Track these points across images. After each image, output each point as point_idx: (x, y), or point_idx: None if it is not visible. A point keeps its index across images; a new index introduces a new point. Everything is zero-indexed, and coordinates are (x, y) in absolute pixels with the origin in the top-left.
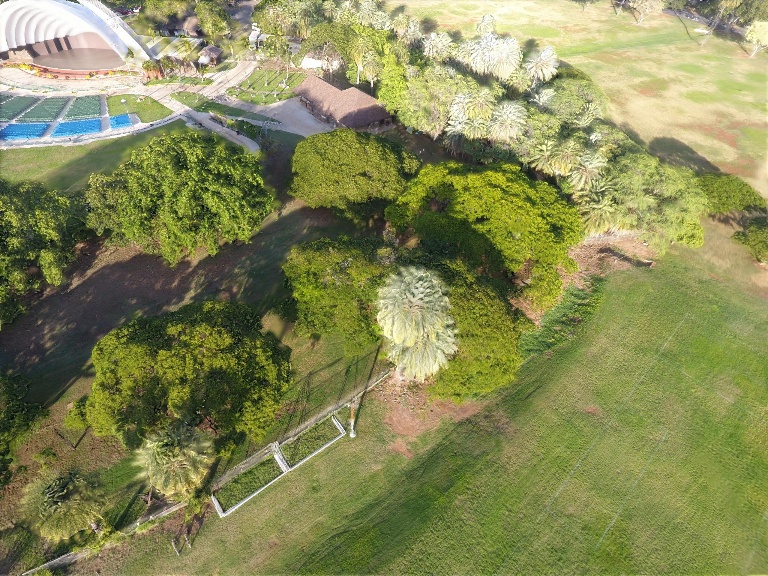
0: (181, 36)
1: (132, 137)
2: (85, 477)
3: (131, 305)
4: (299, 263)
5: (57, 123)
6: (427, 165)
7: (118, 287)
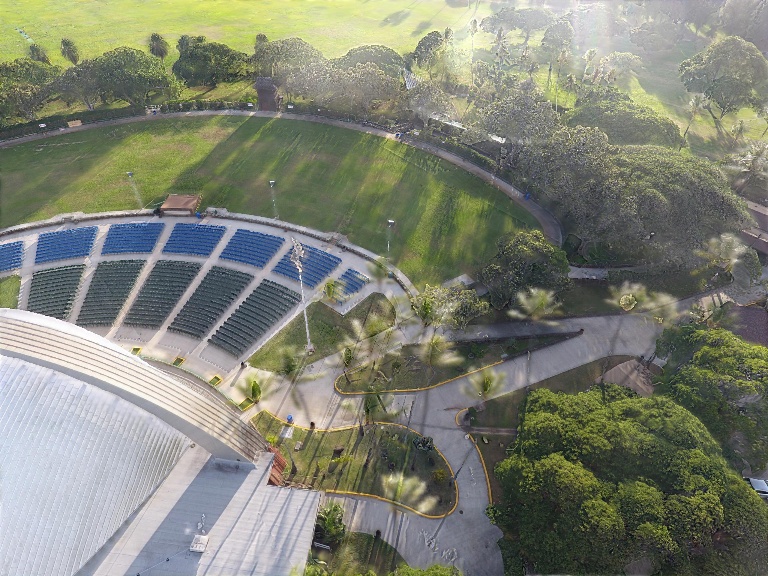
0: None
1: (3, 223)
2: (62, 49)
3: None
4: None
5: (94, 260)
6: None
7: None
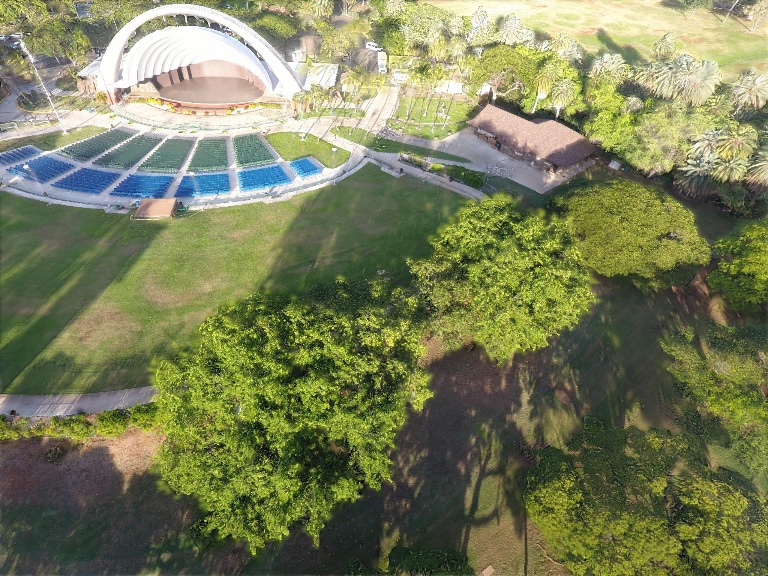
0: (314, 61)
1: (334, 188)
2: None
3: (473, 418)
4: (730, 374)
5: (233, 172)
6: (754, 226)
7: (449, 395)
